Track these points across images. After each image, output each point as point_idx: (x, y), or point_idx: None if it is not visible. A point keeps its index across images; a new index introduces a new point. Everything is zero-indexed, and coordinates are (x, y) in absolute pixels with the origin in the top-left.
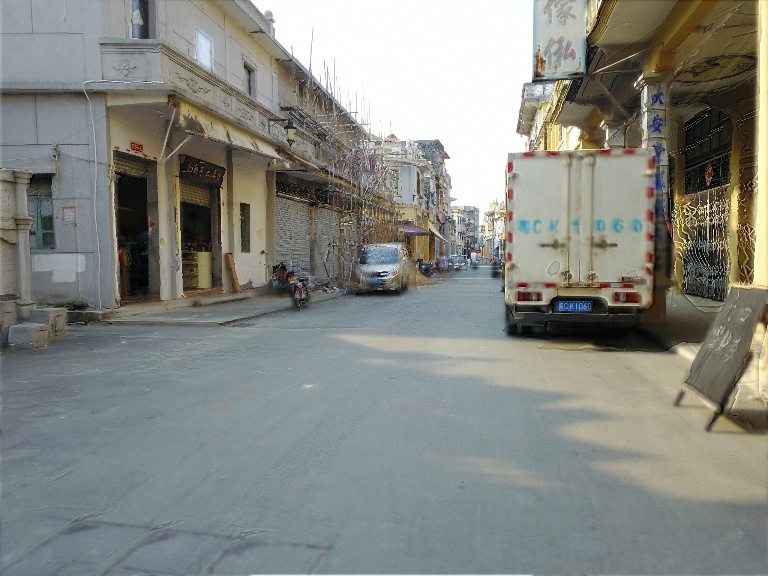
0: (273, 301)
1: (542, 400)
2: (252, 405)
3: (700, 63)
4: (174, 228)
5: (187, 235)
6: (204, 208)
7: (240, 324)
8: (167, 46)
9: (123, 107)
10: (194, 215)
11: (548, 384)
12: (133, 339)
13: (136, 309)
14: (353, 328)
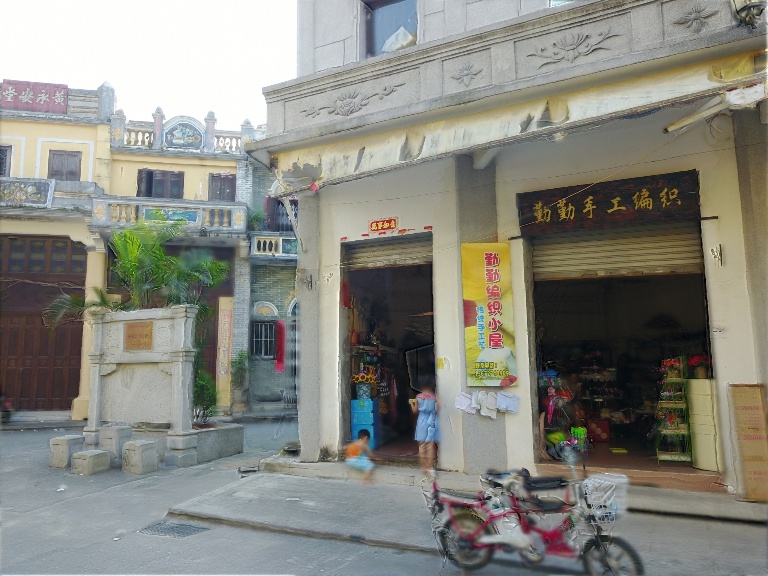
0: (758, 554)
1: None
2: None
3: None
4: (463, 338)
5: (660, 342)
6: (673, 277)
7: (199, 528)
8: (272, 90)
9: (328, 185)
10: (649, 297)
11: None
12: (87, 491)
13: (336, 470)
14: None
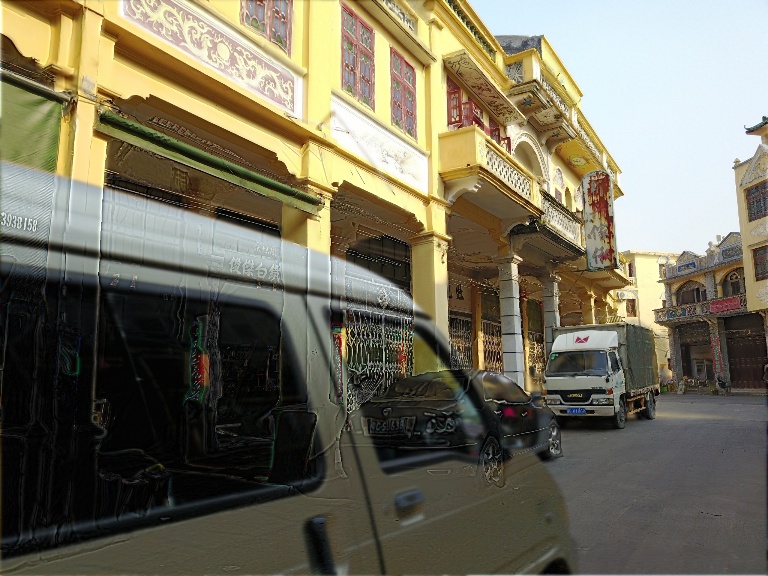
0: None
1: (666, 410)
2: (745, 408)
3: None
4: None
5: None
6: None
7: None
8: None
9: None
10: None
11: (660, 411)
12: None
13: None
14: (761, 420)
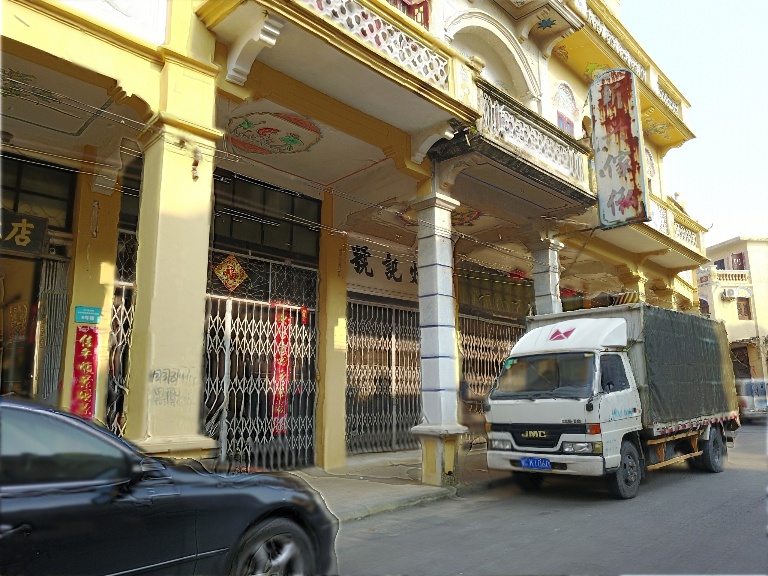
0: None
1: None
2: None
3: (463, 216)
4: None
5: None
6: None
7: None
8: None
9: None
10: None
11: None
12: None
13: None
14: None
